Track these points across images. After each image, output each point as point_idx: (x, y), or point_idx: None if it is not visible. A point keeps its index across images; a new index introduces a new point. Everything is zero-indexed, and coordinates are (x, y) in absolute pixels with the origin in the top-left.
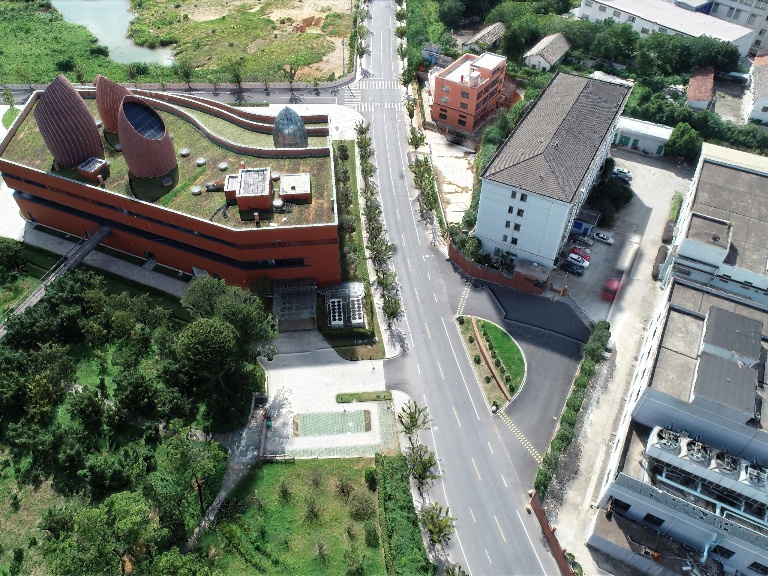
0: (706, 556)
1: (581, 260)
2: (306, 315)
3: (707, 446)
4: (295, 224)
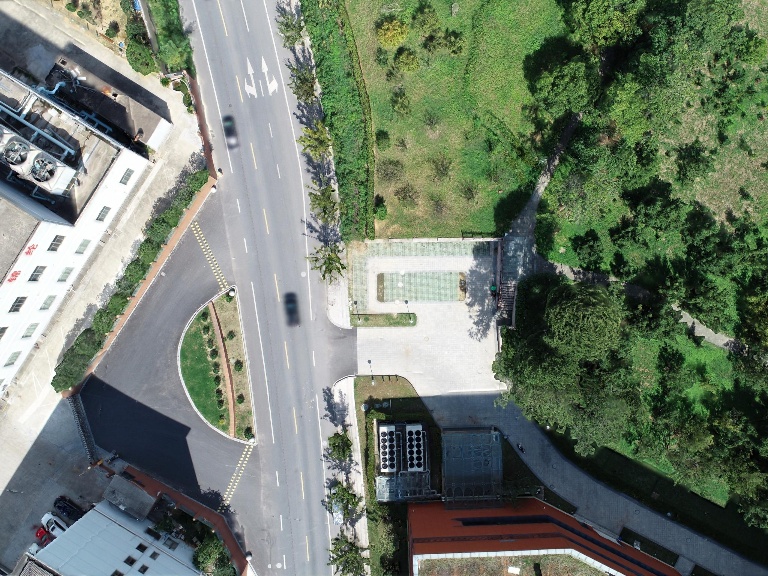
0: (58, 84)
1: (51, 526)
2: (456, 438)
3: (3, 161)
4: (480, 570)
